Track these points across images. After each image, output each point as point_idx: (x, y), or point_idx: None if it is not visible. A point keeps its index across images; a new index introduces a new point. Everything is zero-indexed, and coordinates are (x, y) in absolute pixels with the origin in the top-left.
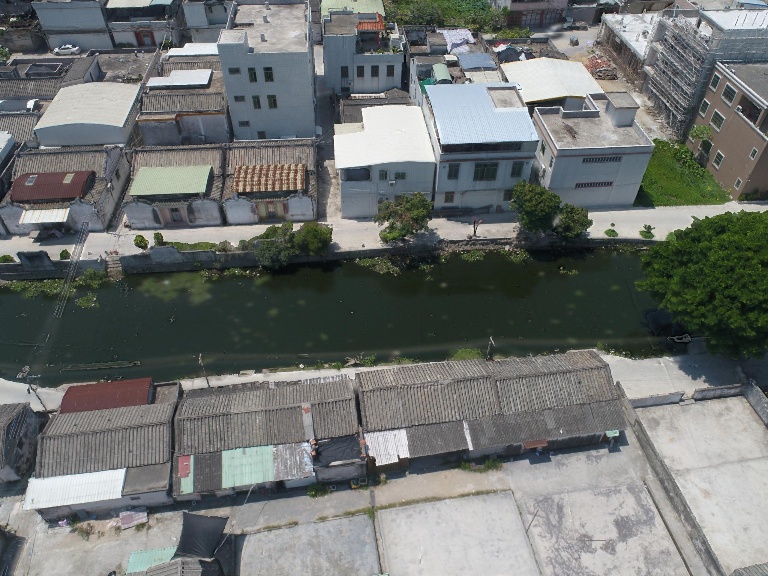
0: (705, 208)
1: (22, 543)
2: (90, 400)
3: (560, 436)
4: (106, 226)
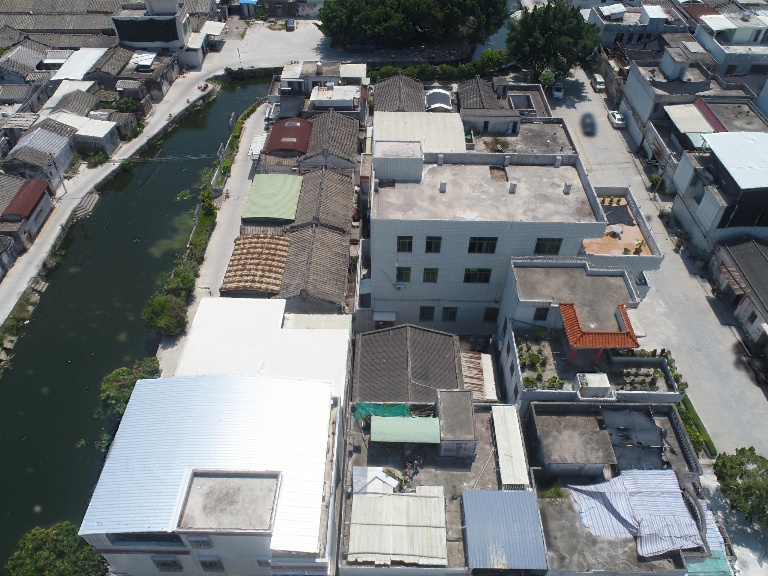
0: None
1: None
2: None
3: None
4: None
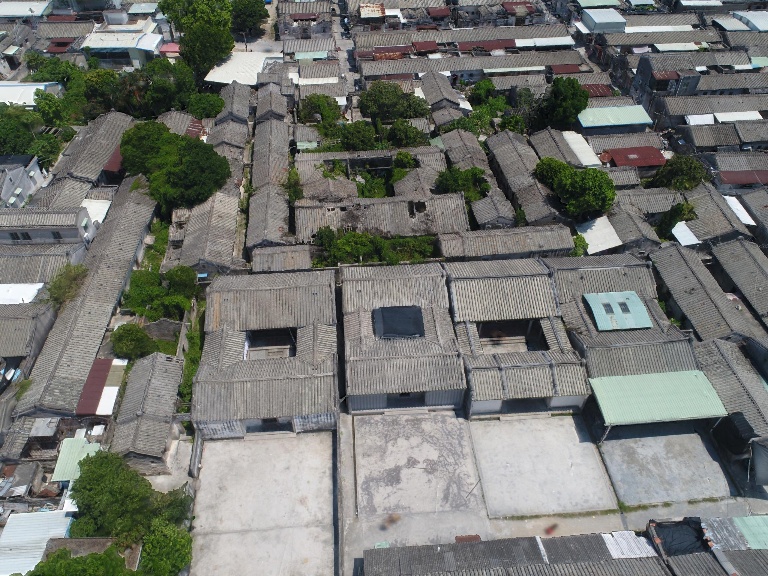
0: None
1: None
2: None
3: (441, 545)
4: None
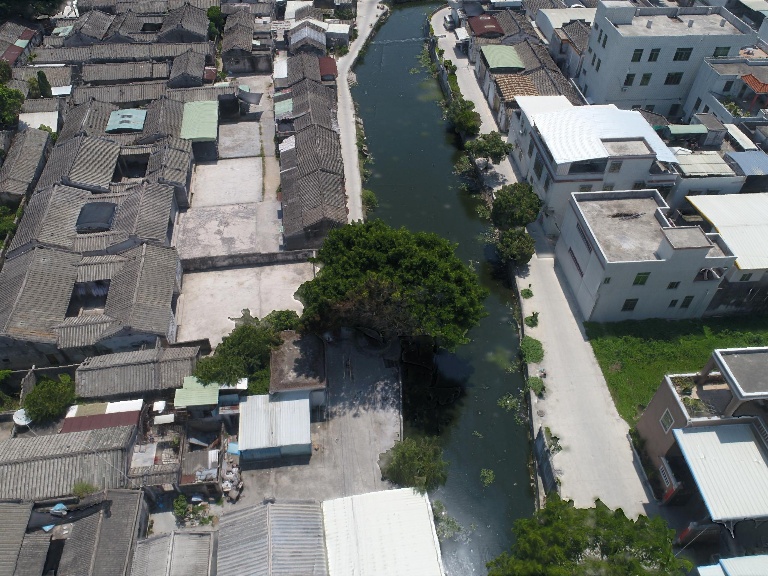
0: (604, 392)
1: (269, 75)
2: None
3: (283, 206)
4: (474, 61)
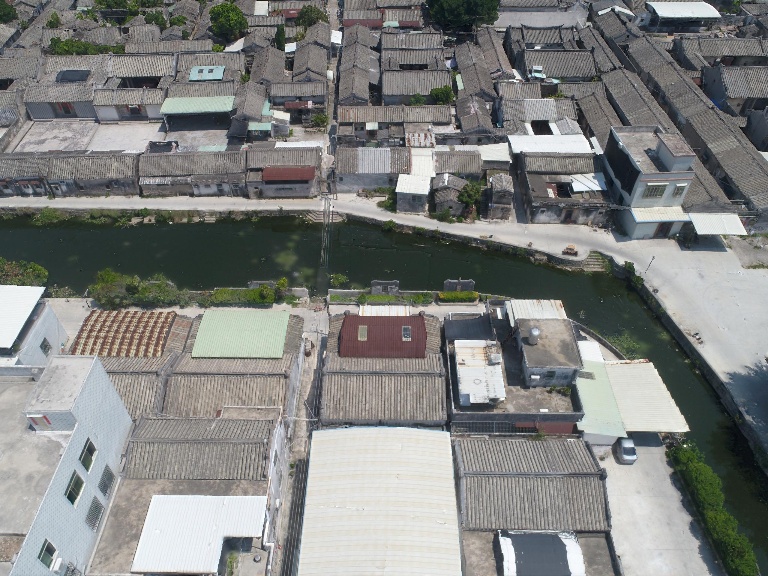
0: None
1: None
2: (298, 169)
3: None
4: None
